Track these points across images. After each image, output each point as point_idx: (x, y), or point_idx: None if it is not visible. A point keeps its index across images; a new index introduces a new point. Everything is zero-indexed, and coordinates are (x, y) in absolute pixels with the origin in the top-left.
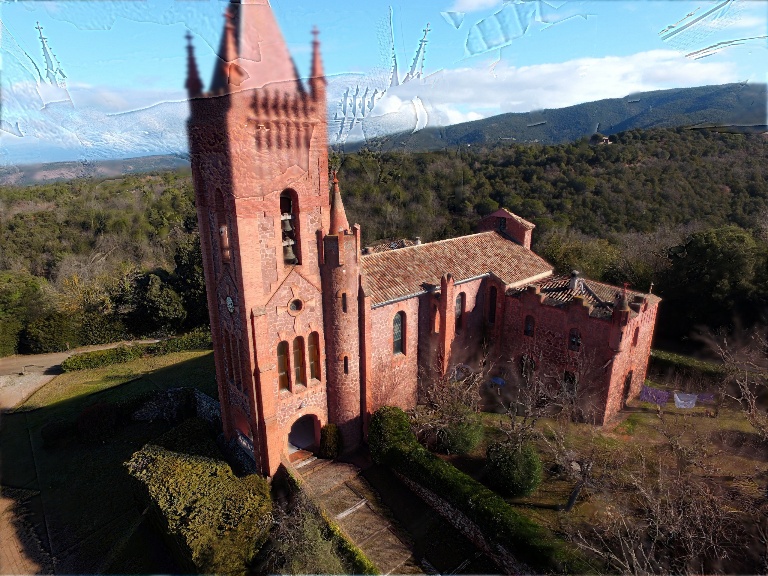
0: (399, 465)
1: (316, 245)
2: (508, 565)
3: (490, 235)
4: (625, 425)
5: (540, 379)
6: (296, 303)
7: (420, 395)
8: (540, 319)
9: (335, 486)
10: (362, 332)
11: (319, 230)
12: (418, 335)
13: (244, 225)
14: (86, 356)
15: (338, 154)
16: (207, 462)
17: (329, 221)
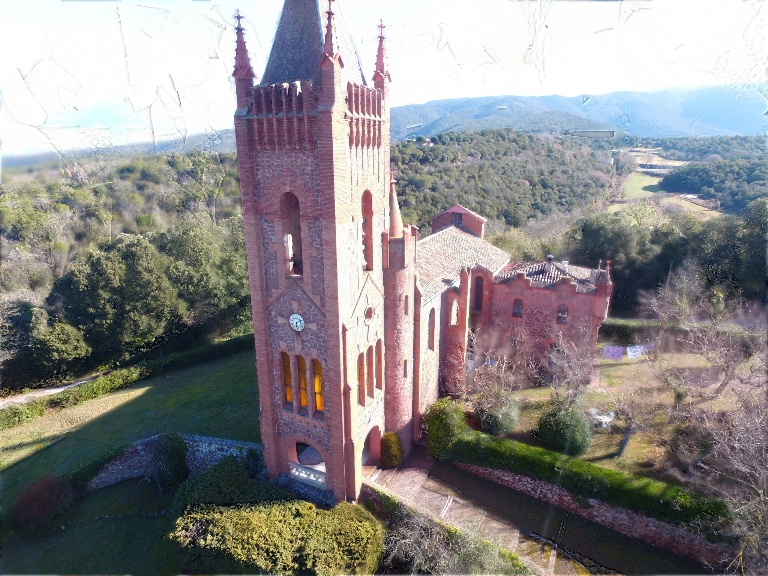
0: (464, 456)
1: (381, 248)
2: (599, 514)
3: (454, 230)
4: (604, 380)
5: (529, 354)
6: (366, 311)
7: (439, 388)
8: (529, 301)
9: (416, 492)
10: (416, 333)
11: (385, 233)
12: (440, 330)
13: (340, 231)
14: (5, 423)
15: (209, 154)
16: (279, 505)
17: (389, 223)
